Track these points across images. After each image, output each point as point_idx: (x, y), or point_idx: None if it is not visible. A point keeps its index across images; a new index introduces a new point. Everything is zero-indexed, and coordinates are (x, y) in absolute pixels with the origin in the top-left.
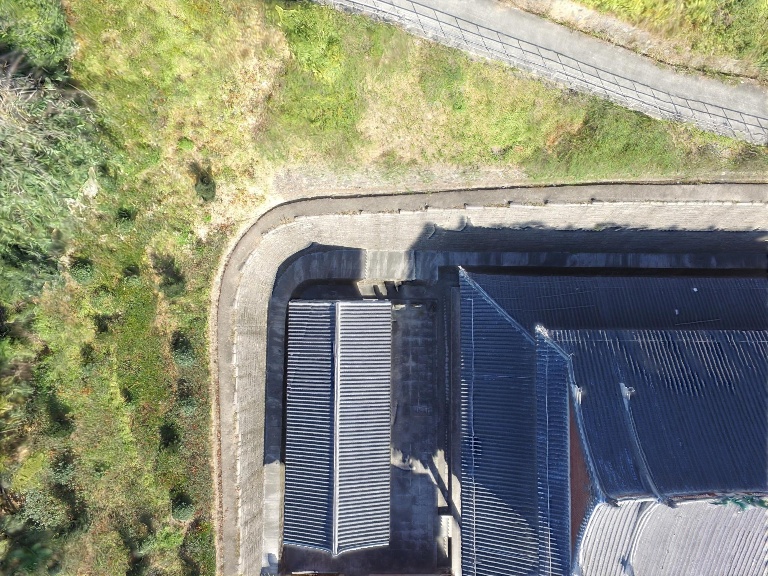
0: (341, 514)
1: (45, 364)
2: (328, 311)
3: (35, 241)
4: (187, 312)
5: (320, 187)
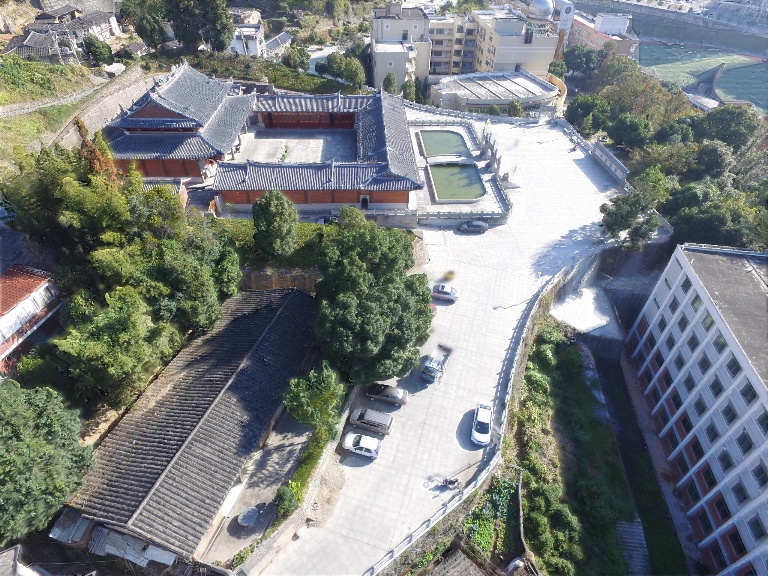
0: None
1: None
2: None
3: None
4: None
5: None
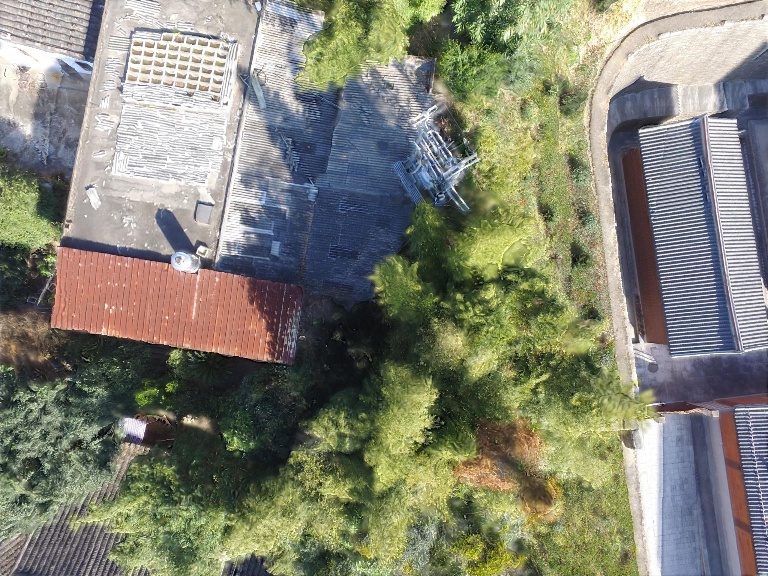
0: None
1: None
2: (689, 129)
3: None
4: (576, 133)
5: (684, 1)
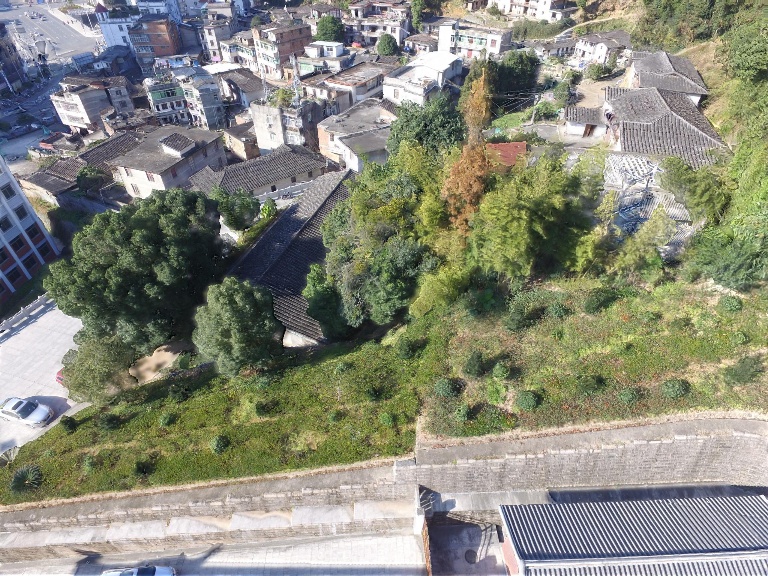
0: (565, 572)
1: (639, 291)
2: None
3: (762, 268)
4: (714, 389)
5: None
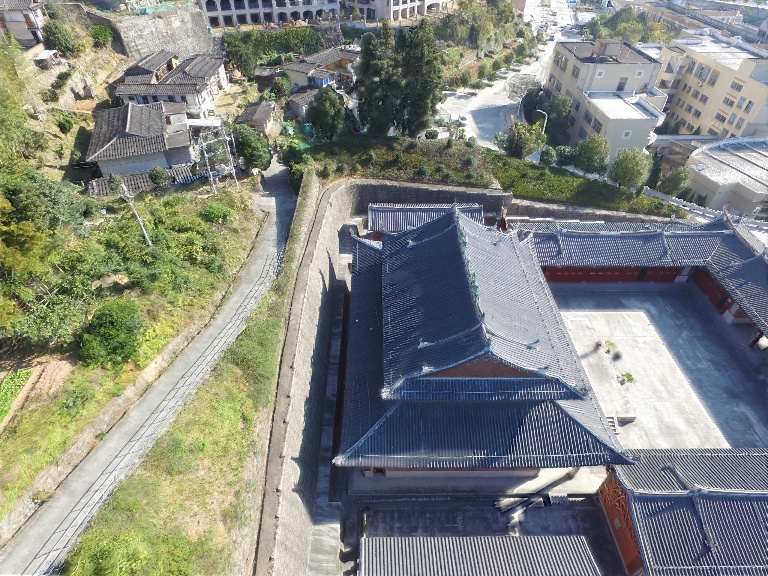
0: None
1: None
2: None
3: None
4: None
5: None
